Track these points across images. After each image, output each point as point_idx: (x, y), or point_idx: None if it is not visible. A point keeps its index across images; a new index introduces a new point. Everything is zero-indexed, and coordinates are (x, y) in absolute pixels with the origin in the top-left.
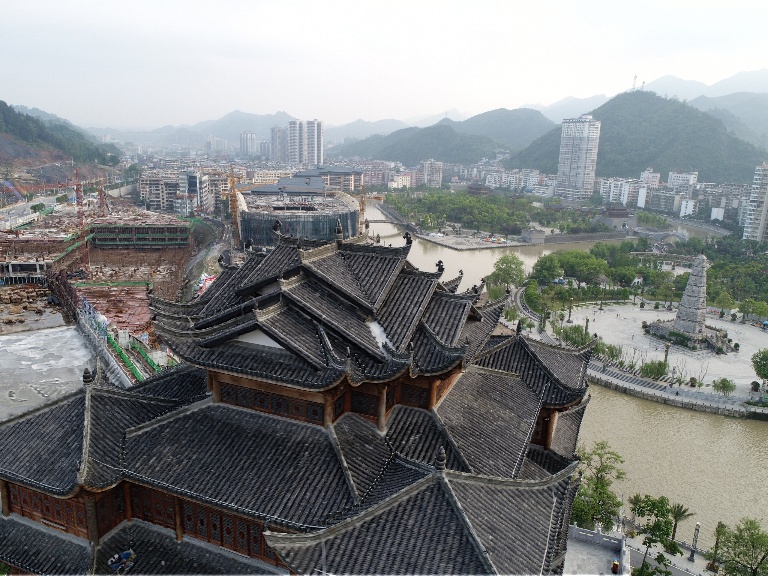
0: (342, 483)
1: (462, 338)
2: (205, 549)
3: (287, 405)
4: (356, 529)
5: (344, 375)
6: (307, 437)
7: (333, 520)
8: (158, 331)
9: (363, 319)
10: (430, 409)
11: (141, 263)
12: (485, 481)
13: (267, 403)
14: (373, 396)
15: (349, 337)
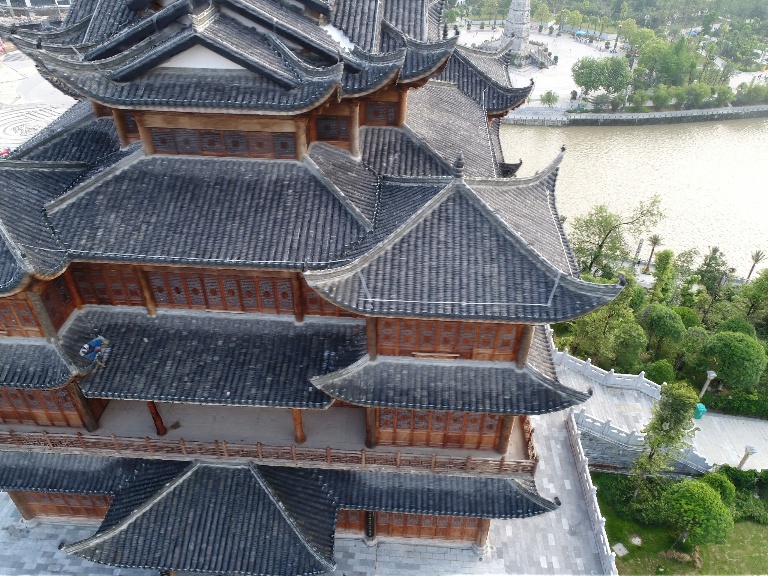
0: (344, 214)
1: None
2: (189, 316)
3: (246, 142)
4: (389, 252)
5: (335, 86)
6: (282, 174)
7: (351, 251)
8: (50, 64)
9: (315, 22)
10: (401, 125)
11: None
12: (493, 184)
13: (219, 144)
14: (343, 117)
15: (313, 44)
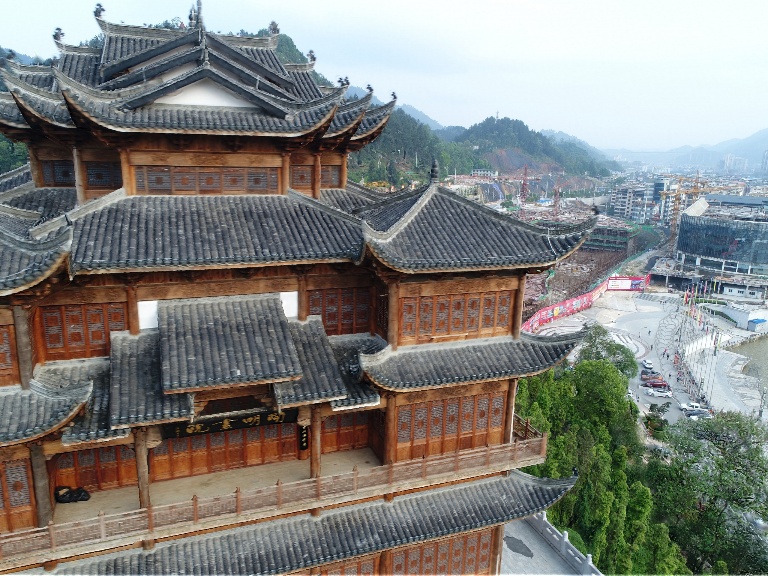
0: None
1: (193, 114)
2: None
3: None
4: None
5: None
6: None
7: None
8: None
9: None
10: None
11: (570, 260)
12: None
13: None
14: None
15: None
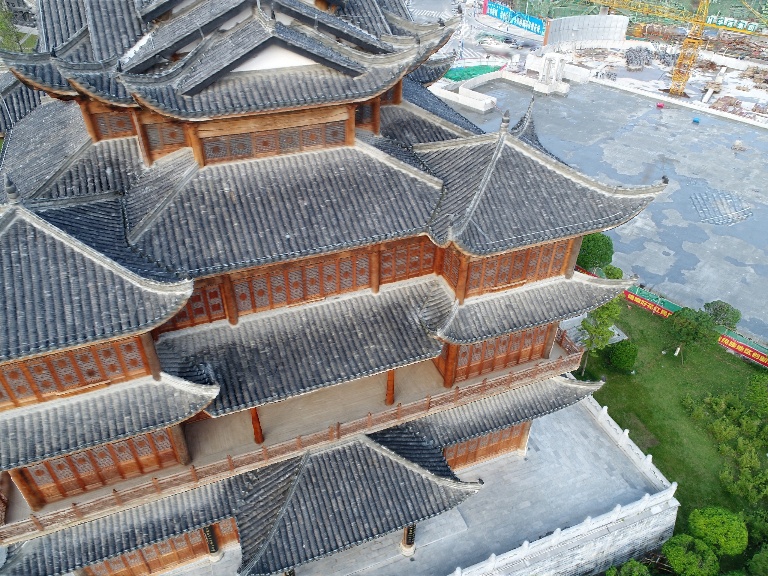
0: None
1: None
2: None
3: None
4: None
5: None
6: None
7: None
8: None
9: None
10: None
11: None
12: None
13: None
14: None
15: None
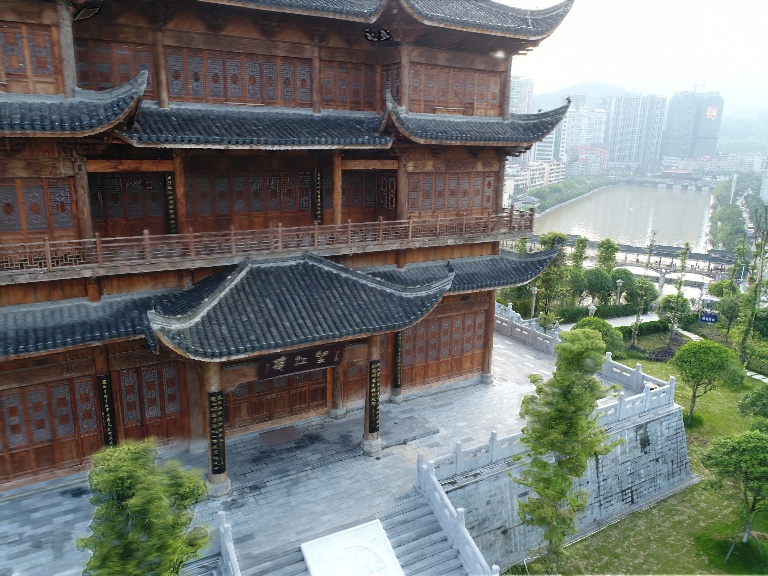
0: None
1: None
2: (207, 109)
3: None
4: None
5: None
6: None
7: None
8: None
9: None
10: None
11: None
12: None
13: None
14: None
15: None
